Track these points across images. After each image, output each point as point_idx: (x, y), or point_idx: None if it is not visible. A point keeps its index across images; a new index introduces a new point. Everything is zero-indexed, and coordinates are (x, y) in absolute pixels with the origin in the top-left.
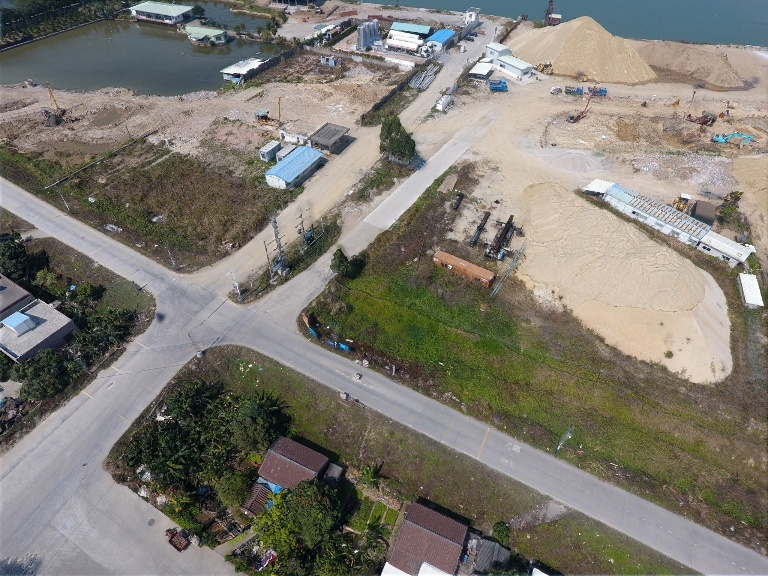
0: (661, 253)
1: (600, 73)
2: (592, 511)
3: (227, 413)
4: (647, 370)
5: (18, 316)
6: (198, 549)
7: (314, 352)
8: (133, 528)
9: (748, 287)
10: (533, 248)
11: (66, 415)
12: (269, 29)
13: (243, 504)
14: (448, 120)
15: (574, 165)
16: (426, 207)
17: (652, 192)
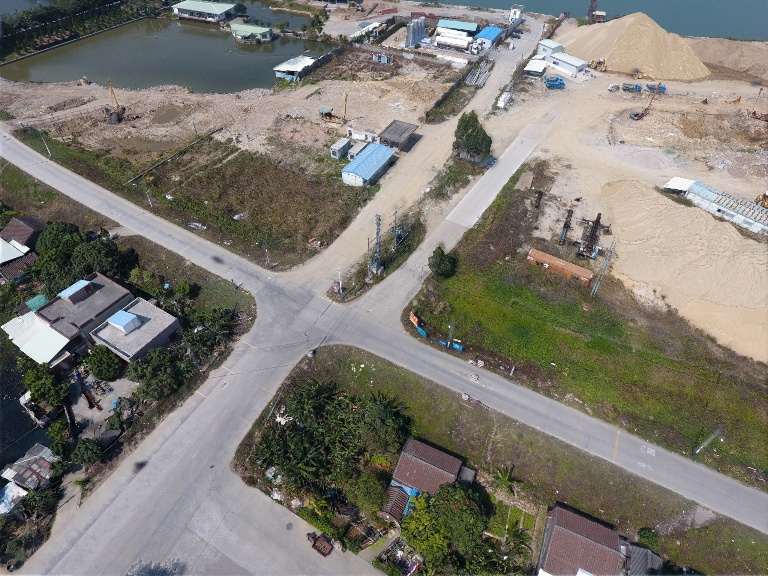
0: None
1: (655, 70)
2: (742, 517)
3: (347, 414)
4: (766, 371)
5: (124, 315)
6: (342, 554)
7: (425, 352)
8: (272, 532)
9: None
10: (625, 246)
11: (184, 416)
12: (313, 27)
13: (382, 508)
14: (511, 117)
15: (647, 163)
16: (507, 205)
17: (731, 190)
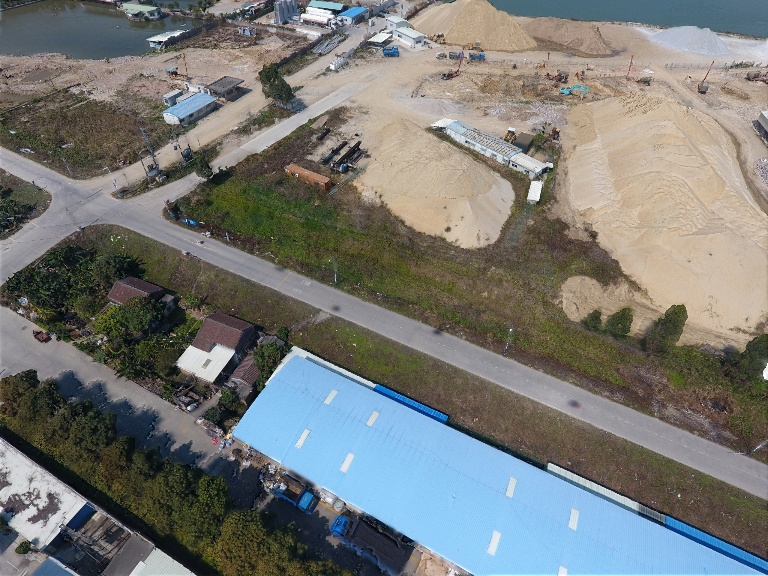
0: (454, 158)
1: (485, 42)
2: (349, 317)
3: None
4: (431, 241)
5: None
6: (56, 342)
7: (171, 228)
8: (10, 331)
9: (533, 189)
10: (372, 165)
11: None
12: None
13: (93, 315)
14: (338, 77)
15: (433, 110)
16: (295, 138)
17: (491, 129)
